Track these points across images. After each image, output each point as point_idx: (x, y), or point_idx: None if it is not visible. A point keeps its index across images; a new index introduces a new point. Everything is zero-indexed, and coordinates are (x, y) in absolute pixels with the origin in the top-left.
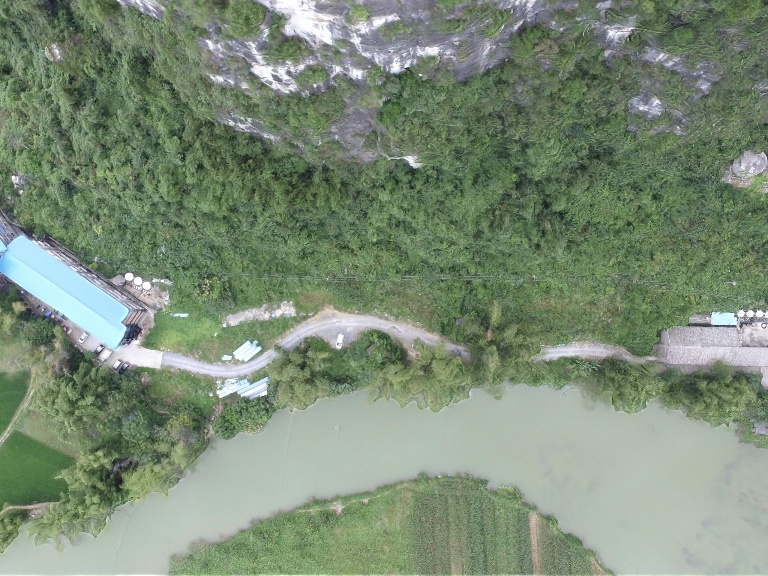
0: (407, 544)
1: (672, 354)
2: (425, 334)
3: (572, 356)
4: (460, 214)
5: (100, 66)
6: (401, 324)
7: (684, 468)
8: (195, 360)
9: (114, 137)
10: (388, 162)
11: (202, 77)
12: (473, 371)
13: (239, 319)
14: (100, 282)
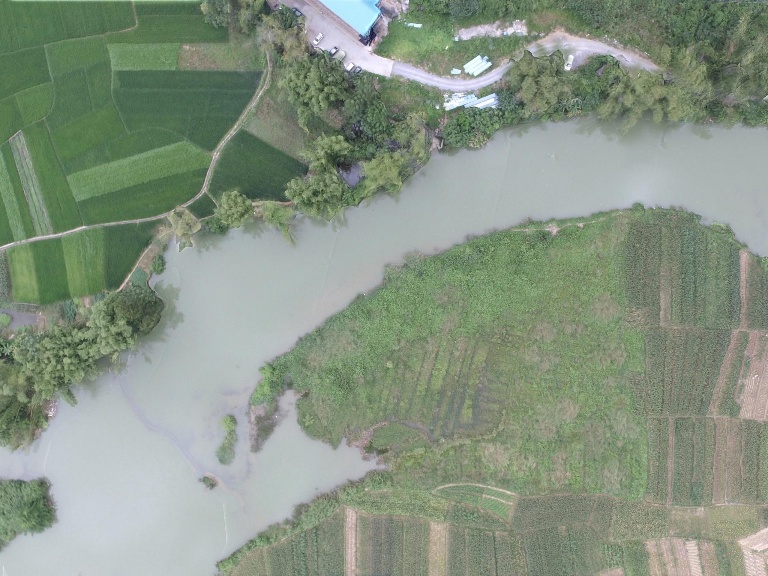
0: (619, 270)
1: None
2: (651, 65)
3: None
4: None
5: None
6: (629, 53)
7: None
8: (425, 71)
9: None
10: None
11: None
12: (712, 86)
13: (471, 34)
14: None
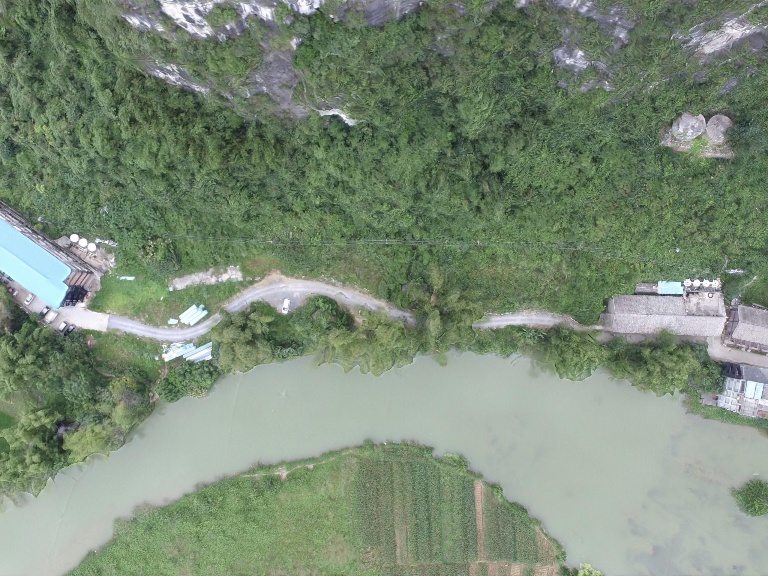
0: (351, 510)
1: (617, 322)
2: (372, 300)
3: (519, 324)
4: (397, 173)
5: (31, 16)
6: (348, 290)
7: (631, 438)
8: (141, 323)
9: (50, 91)
10: (321, 118)
11: (118, 19)
12: (416, 336)
13: (186, 283)
14: (45, 243)
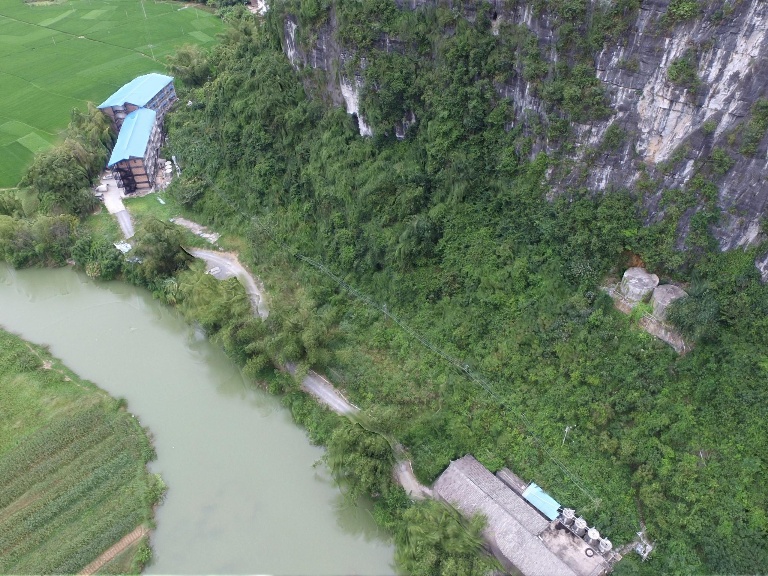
0: (33, 437)
1: (447, 477)
2: None
3: None
4: (361, 177)
5: None
6: (263, 297)
7: None
8: (132, 223)
9: None
10: (346, 114)
11: None
12: None
13: (183, 223)
14: None
